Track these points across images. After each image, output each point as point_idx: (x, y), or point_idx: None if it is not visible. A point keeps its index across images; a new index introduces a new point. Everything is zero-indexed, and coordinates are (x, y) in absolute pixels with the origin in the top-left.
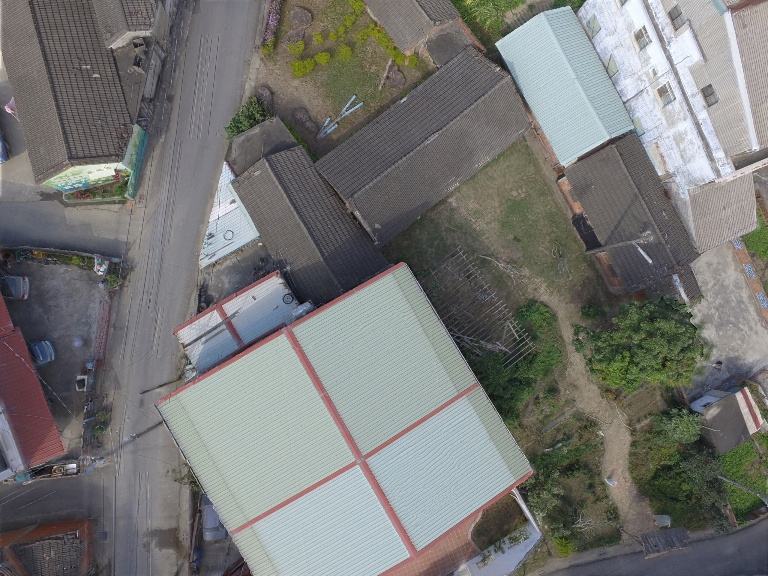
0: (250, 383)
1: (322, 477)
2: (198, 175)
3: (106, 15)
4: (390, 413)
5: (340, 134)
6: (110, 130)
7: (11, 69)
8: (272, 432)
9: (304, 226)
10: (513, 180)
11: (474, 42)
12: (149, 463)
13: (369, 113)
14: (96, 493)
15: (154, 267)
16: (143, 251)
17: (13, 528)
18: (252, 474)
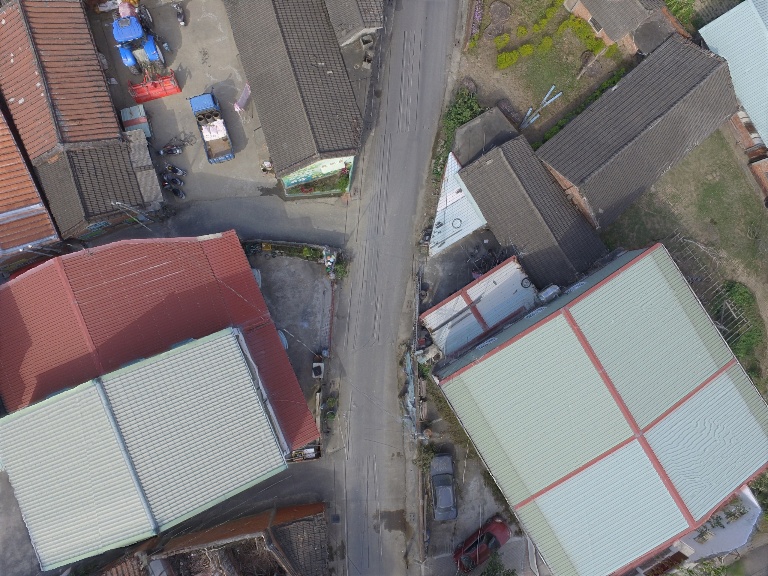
0: (530, 362)
1: (602, 451)
2: (408, 167)
3: (340, 13)
4: (661, 388)
5: (542, 124)
6: (346, 124)
7: (250, 68)
8: (552, 409)
9: (539, 212)
10: (707, 164)
11: (678, 30)
12: (375, 447)
13: (568, 102)
14: (327, 477)
15: (371, 257)
16: (360, 242)
17: (252, 512)
18: (534, 450)
